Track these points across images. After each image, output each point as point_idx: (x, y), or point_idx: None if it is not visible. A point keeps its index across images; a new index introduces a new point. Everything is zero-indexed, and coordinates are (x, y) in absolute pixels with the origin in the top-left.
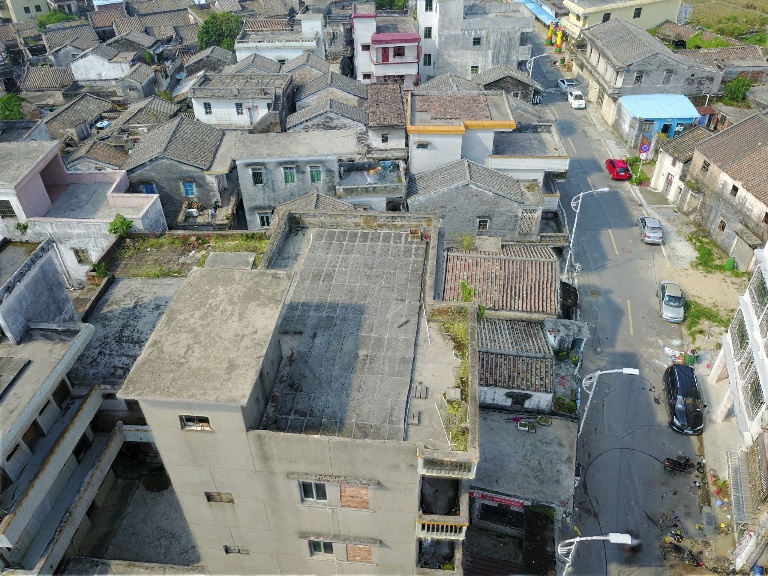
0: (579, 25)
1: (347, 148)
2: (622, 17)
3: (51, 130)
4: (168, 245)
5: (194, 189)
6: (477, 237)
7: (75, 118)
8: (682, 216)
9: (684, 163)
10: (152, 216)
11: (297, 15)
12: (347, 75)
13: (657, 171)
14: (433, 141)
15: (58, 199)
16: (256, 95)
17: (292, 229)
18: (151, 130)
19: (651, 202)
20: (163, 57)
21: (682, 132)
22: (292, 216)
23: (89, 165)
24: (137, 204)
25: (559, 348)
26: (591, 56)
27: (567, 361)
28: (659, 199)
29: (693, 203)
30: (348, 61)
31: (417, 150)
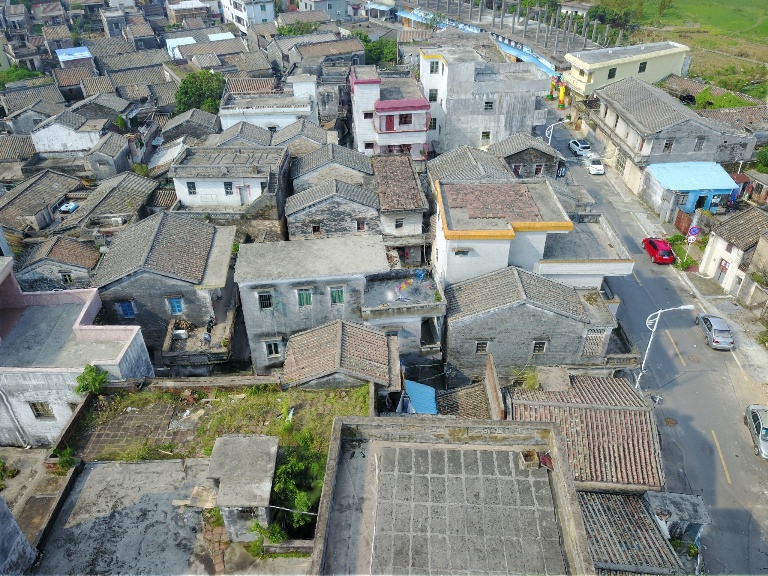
0: (583, 80)
1: (376, 263)
2: (627, 72)
3: (6, 218)
4: (154, 402)
5: (182, 306)
6: (538, 368)
7: (35, 201)
8: (744, 310)
9: (744, 251)
10: (132, 356)
11: (288, 77)
12: (343, 140)
13: (708, 256)
14: (475, 247)
15: (10, 331)
16: (248, 174)
17: (345, 444)
18: (127, 228)
19: (705, 292)
20: (137, 121)
21: (719, 204)
22: (345, 427)
23: (51, 268)
24: (112, 338)
25: (669, 533)
26: (606, 117)
27: (680, 550)
28: (713, 288)
29: (759, 297)
30: (341, 122)
31: (455, 257)
